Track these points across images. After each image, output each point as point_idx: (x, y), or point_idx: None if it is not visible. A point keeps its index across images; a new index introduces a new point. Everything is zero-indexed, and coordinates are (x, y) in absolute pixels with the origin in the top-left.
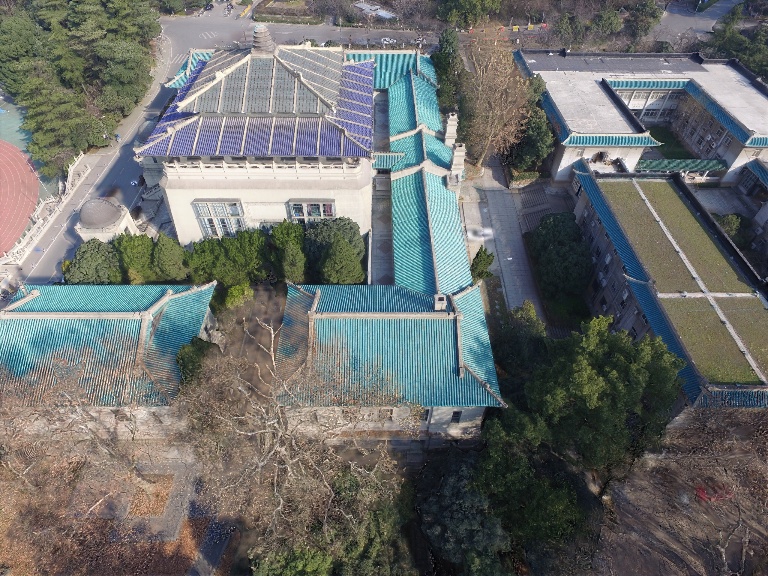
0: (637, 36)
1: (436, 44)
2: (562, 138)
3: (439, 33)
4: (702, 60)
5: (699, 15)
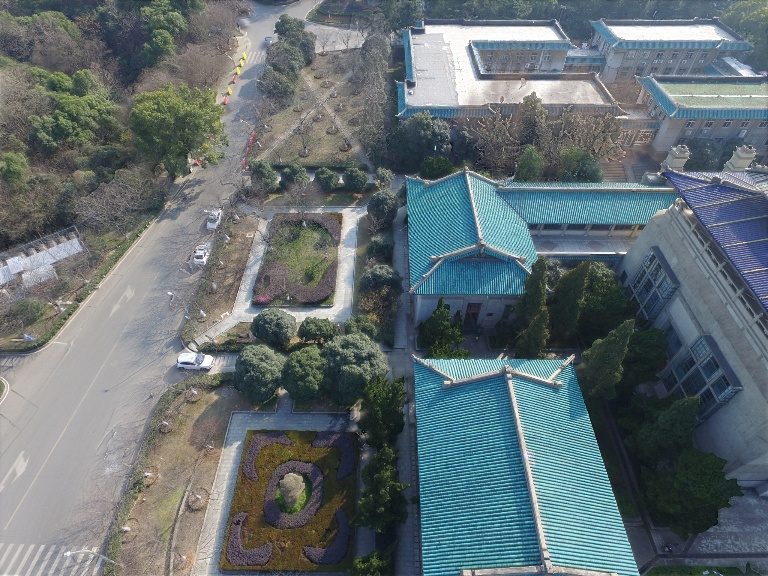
0: (314, 51)
1: (226, 202)
2: (615, 113)
3: (228, 184)
4: (423, 30)
5: (257, 17)
